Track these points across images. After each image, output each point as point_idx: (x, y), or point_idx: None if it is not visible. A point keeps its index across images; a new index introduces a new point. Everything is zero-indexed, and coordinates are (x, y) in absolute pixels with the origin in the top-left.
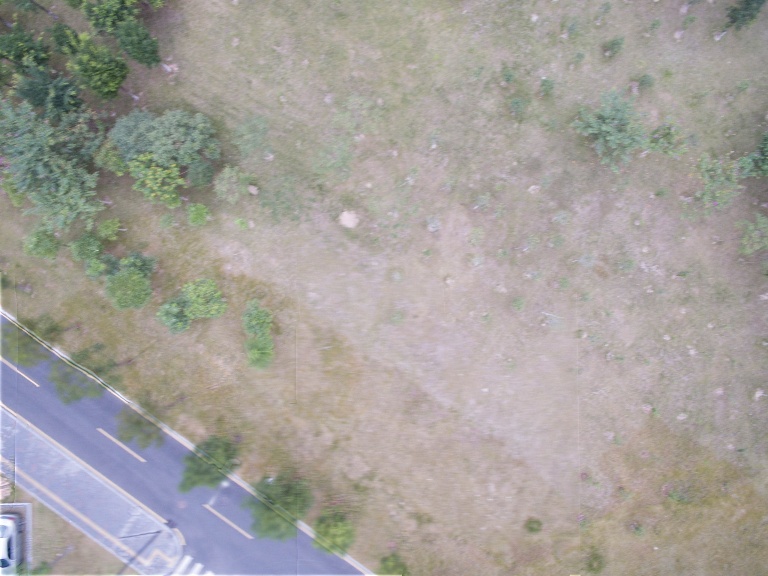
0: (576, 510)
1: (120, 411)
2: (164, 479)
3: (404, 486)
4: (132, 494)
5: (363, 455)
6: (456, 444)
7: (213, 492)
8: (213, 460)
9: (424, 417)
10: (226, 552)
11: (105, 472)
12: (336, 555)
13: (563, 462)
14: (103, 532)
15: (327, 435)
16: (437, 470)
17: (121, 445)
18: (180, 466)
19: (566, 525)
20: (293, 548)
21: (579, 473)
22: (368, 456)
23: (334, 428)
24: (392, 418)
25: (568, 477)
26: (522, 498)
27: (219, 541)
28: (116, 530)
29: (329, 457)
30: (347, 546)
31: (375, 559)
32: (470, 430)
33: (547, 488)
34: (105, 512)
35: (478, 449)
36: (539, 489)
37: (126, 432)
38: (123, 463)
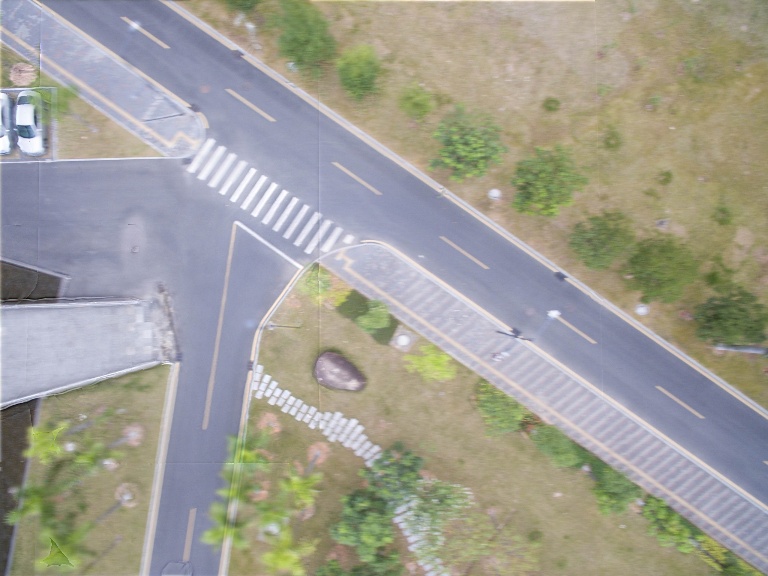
0: (593, 89)
1: (144, 1)
2: (187, 65)
3: (424, 67)
4: (156, 79)
5: (383, 38)
6: (475, 27)
7: (235, 77)
8: (235, 46)
9: (443, 0)
10: (248, 135)
11: (129, 59)
12: (357, 136)
13: (580, 41)
14: (127, 115)
15: (348, 19)
16: (456, 52)
17: (145, 33)
18: (203, 53)
19: (583, 104)
20: (314, 131)
21: (596, 52)
22: (388, 39)
23: (354, 11)
24: (412, 2)
25: (585, 56)
26: (540, 78)
27: (241, 124)
28: (140, 114)
29: (350, 40)
30: (368, 127)
31: (395, 140)
32: (488, 12)
33: (565, 67)
34: (129, 96)
35: (496, 30)
36: (557, 68)
37: (150, 20)
38: (147, 50)
